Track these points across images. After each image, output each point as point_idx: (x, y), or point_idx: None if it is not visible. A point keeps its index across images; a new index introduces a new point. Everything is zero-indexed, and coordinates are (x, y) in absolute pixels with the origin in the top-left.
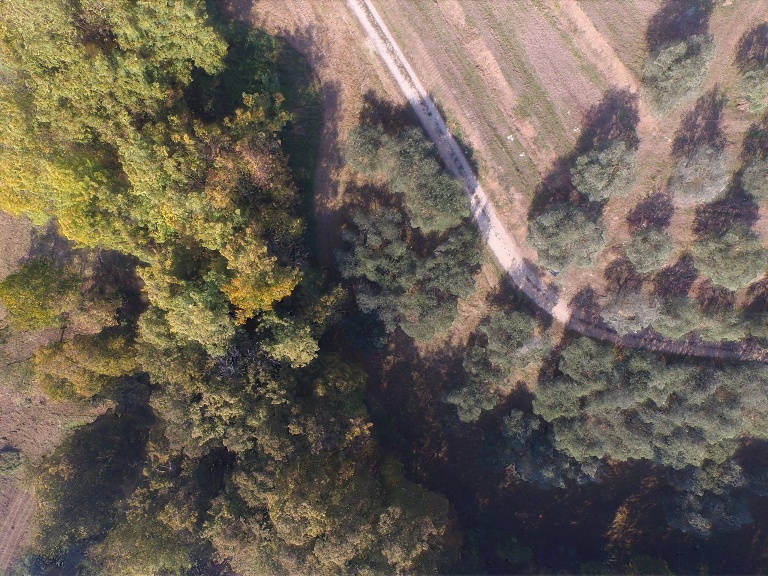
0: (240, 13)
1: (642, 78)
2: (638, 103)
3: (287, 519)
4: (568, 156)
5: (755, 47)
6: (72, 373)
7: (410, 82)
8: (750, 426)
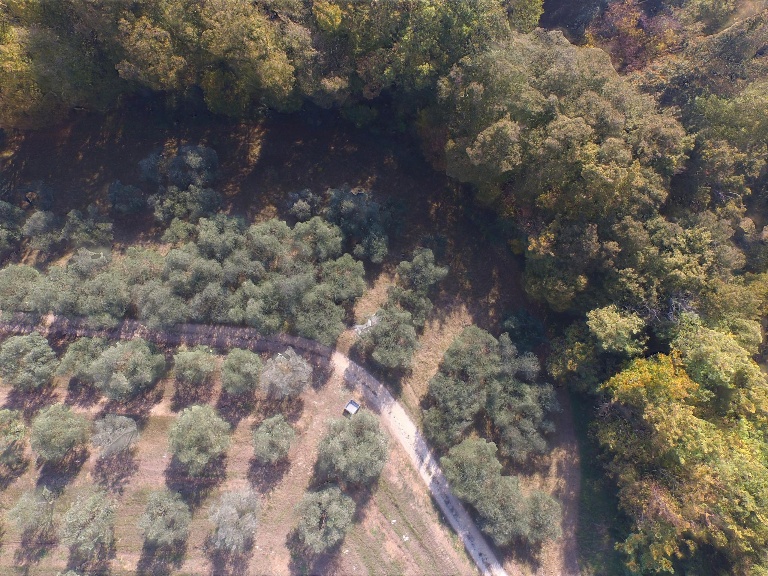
0: None
1: None
2: None
3: (622, 162)
4: None
5: None
6: None
7: None
8: (154, 261)
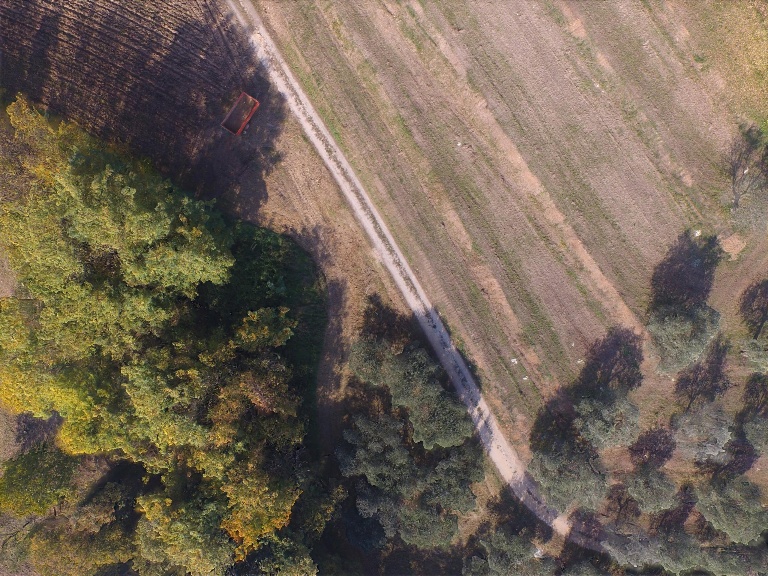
0: (247, 214)
1: (647, 322)
2: (642, 344)
3: None
4: (571, 386)
5: (759, 299)
6: (68, 570)
7: (415, 294)
8: None
